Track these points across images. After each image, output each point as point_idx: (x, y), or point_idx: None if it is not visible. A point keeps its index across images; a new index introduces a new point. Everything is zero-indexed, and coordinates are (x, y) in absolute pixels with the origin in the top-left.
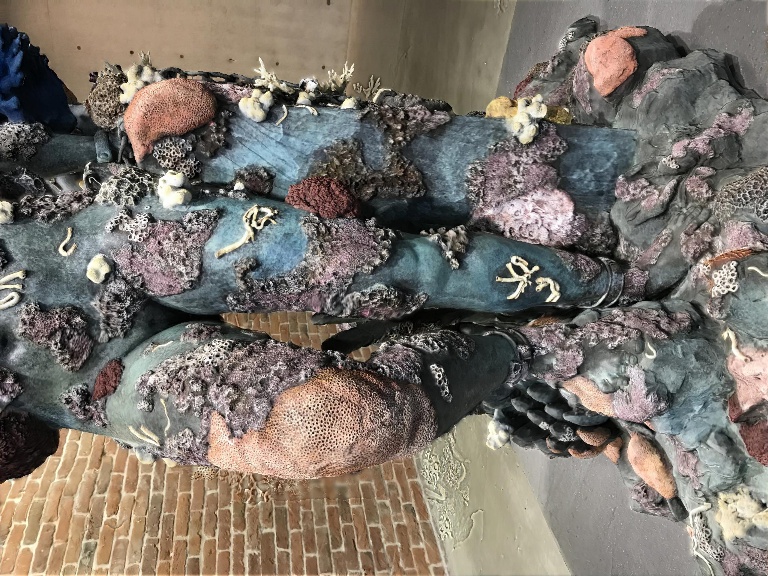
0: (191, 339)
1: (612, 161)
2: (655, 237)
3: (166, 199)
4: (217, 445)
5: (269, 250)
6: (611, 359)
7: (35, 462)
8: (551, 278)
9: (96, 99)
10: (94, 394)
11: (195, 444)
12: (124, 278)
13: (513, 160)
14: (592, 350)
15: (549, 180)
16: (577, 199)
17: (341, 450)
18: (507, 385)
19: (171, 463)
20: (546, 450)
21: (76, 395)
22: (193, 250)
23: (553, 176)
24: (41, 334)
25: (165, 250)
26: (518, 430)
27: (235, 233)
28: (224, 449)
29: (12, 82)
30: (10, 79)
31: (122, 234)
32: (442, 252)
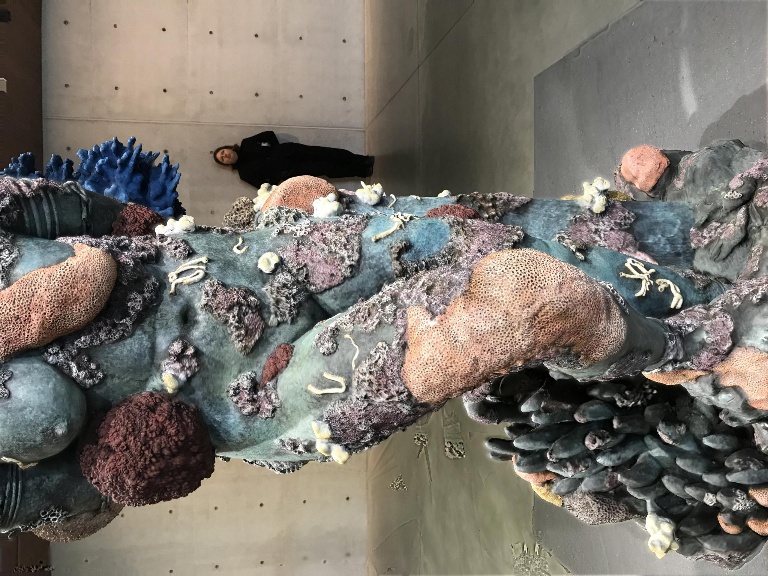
0: (360, 304)
1: (678, 227)
2: (746, 262)
3: (323, 209)
4: (417, 337)
5: (418, 234)
6: (761, 311)
7: (194, 475)
8: (669, 280)
9: (233, 213)
10: (263, 379)
11: (390, 355)
12: (290, 271)
13: (593, 228)
14: (738, 312)
15: (629, 243)
16: (659, 260)
17: (551, 287)
18: (652, 464)
19: (342, 455)
20: (721, 547)
21: (246, 380)
22: (353, 236)
23: (631, 240)
24: (221, 306)
25: (328, 238)
26: (681, 522)
27: (386, 224)
28: (425, 338)
29: (167, 201)
30: (166, 199)
31: (287, 235)
32: (566, 247)
